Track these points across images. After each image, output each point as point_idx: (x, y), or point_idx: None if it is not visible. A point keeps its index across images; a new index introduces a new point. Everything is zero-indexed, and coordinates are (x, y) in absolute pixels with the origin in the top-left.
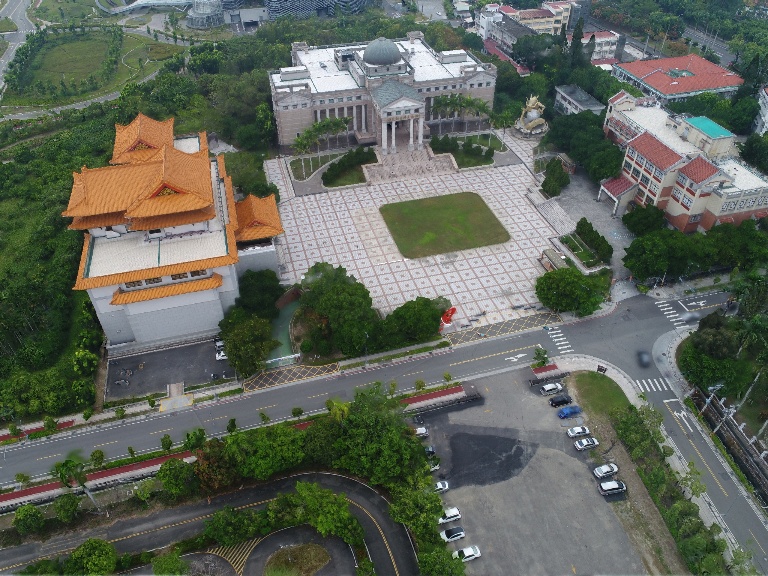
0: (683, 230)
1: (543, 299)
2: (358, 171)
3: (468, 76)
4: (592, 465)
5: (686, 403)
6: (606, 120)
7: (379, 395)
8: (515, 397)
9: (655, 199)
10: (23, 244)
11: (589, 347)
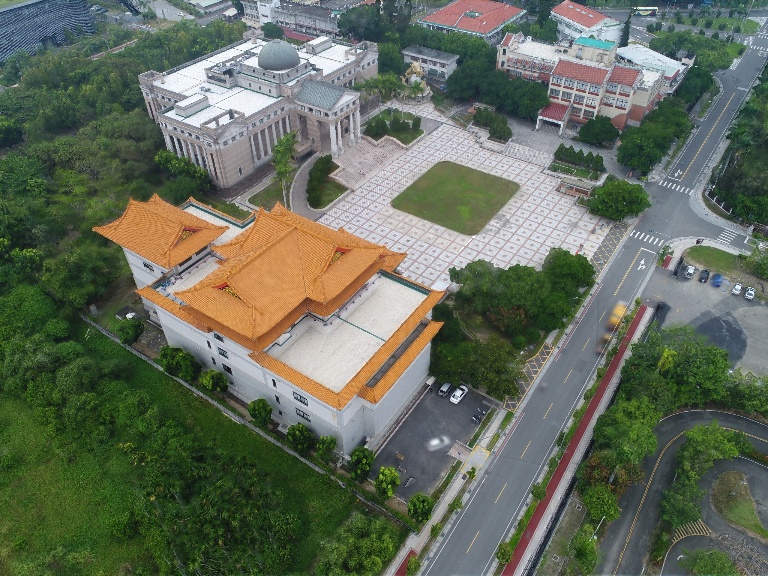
0: (623, 127)
1: (613, 214)
2: (330, 182)
3: (359, 58)
4: (767, 304)
5: (756, 237)
6: (501, 63)
7: (664, 332)
8: (678, 291)
9: (596, 110)
10: (45, 440)
11: (668, 233)
